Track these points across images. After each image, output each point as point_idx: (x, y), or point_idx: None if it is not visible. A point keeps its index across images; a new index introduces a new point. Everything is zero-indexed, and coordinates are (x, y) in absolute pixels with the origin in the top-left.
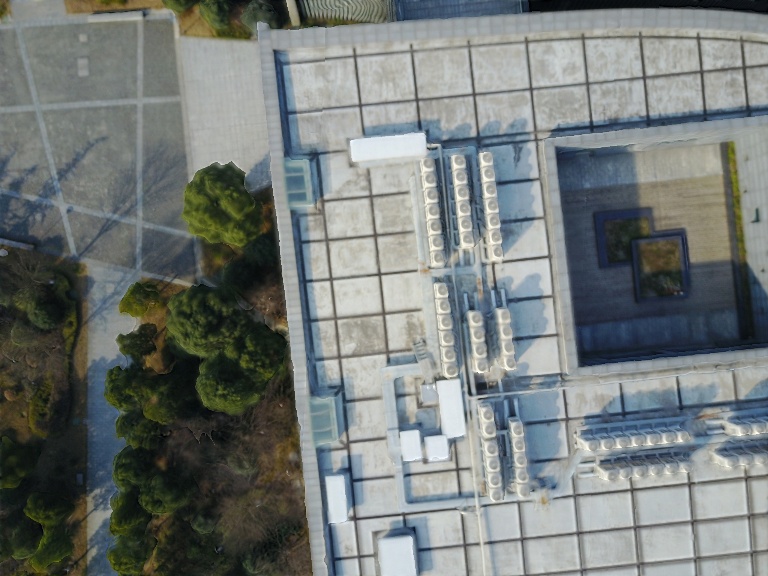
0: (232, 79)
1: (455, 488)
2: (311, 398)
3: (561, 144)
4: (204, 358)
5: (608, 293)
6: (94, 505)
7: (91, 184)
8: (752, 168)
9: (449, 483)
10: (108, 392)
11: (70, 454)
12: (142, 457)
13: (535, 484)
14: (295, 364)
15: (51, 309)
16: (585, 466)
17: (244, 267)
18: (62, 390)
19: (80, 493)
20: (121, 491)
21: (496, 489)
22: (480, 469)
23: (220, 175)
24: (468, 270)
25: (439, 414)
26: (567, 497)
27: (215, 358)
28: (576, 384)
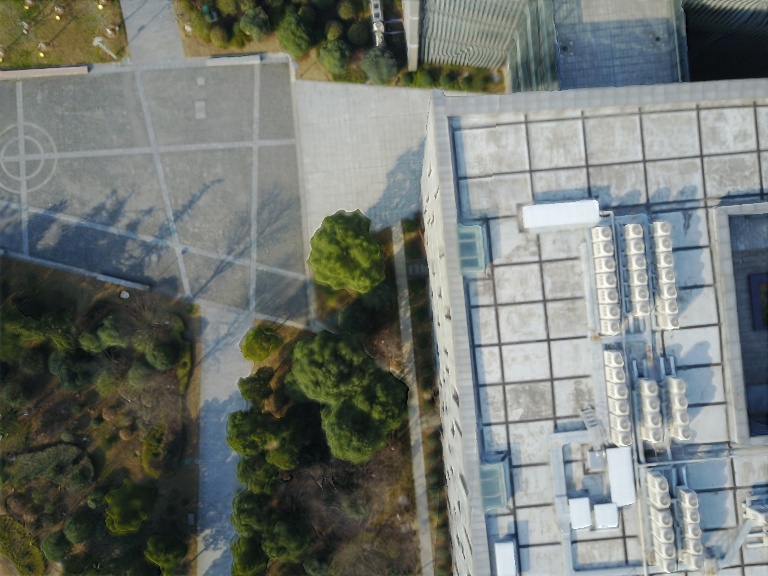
0: (347, 123)
1: (622, 556)
2: (481, 464)
3: (734, 212)
4: (325, 404)
5: (763, 356)
6: (204, 545)
7: (206, 226)
8: None
9: (616, 551)
10: (234, 437)
11: (182, 494)
12: (263, 502)
13: (704, 554)
14: (465, 429)
15: (168, 350)
16: (754, 536)
17: (361, 312)
18: (176, 430)
19: (191, 533)
20: (243, 536)
21: (670, 560)
22: (649, 538)
23: (349, 224)
24: (638, 337)
25: (606, 481)
26: (736, 567)
27: (342, 406)
28: (745, 453)
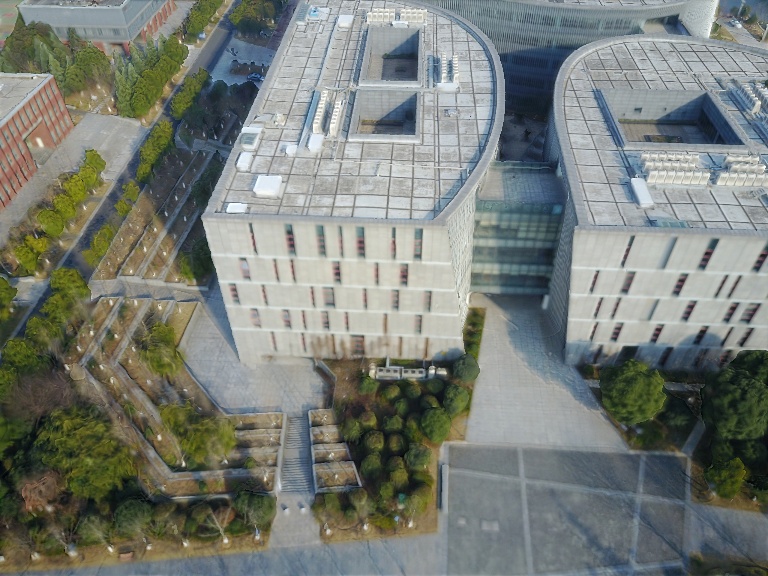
0: (504, 407)
1: None
2: None
3: None
4: (766, 419)
5: None
6: None
7: (606, 535)
8: (616, 108)
9: None
10: None
11: None
12: None
13: None
14: None
15: None
16: None
17: (672, 400)
18: None
19: None
20: None
21: None
22: None
23: (615, 371)
24: None
25: None
26: None
27: None
28: (752, 150)
